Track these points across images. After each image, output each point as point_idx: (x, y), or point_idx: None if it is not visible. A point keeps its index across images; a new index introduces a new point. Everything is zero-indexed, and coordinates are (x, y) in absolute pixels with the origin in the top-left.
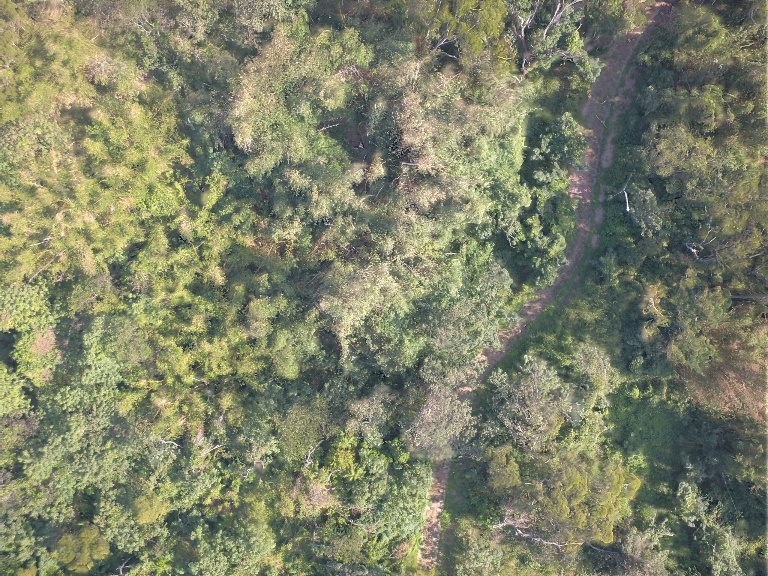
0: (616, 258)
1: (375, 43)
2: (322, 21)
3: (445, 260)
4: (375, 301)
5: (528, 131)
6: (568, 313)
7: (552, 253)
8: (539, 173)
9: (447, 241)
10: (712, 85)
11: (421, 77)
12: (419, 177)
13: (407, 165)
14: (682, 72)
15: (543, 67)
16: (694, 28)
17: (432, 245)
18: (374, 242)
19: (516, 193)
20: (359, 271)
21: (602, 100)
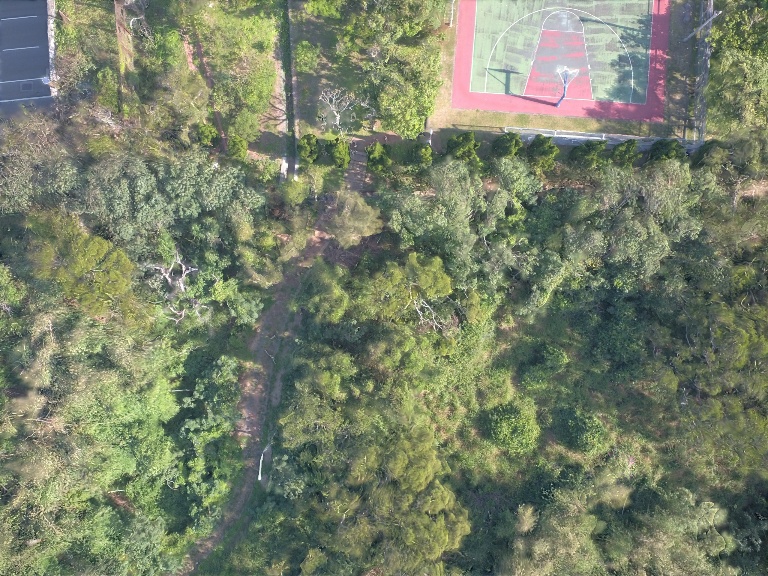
0: (275, 507)
1: (26, 280)
2: (3, 233)
3: (88, 515)
4: (12, 560)
5: (191, 369)
6: (231, 559)
7: (206, 504)
8: (190, 423)
9: (117, 475)
10: (337, 357)
11: (56, 329)
12: (53, 435)
13: (41, 422)
14: (325, 329)
15: (206, 303)
16: (320, 296)
17: (79, 496)
18: (24, 489)
19: (149, 456)
20: (8, 519)
21: (271, 335)
